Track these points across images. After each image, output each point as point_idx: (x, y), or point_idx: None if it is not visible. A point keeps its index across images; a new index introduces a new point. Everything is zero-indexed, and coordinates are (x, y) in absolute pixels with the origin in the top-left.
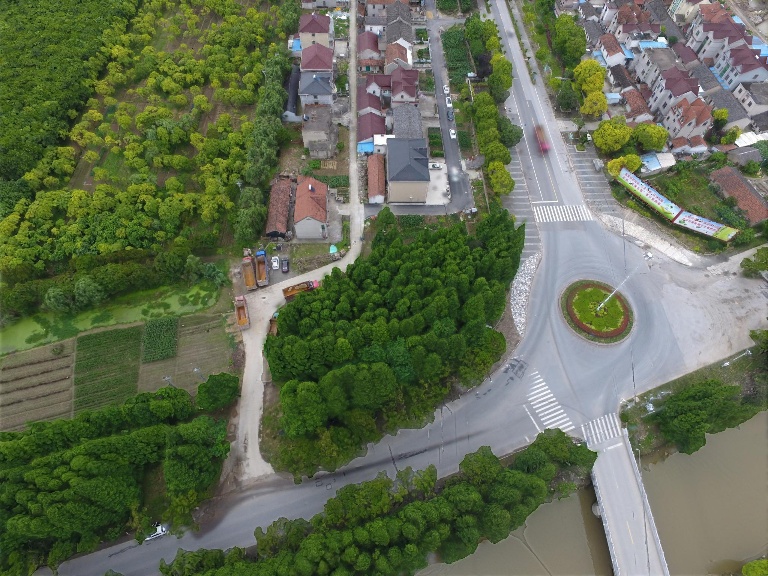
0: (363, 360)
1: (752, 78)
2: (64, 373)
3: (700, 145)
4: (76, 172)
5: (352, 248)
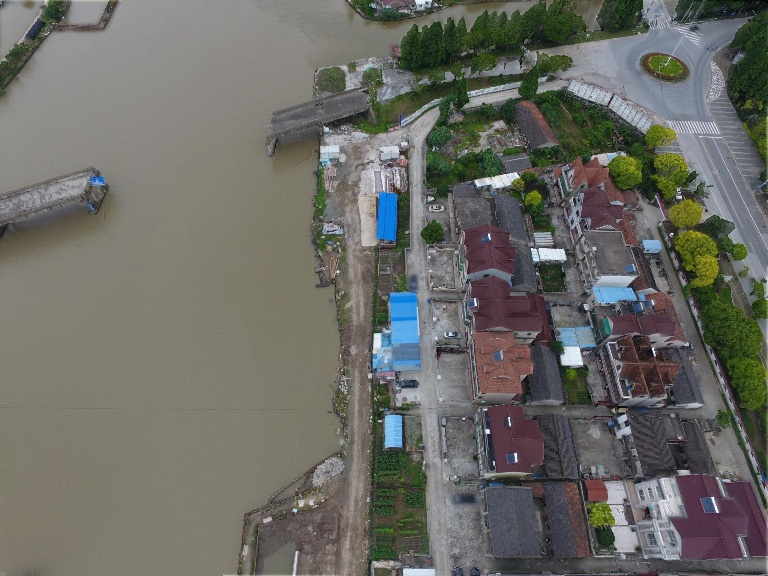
0: None
1: None
2: None
3: None
4: None
5: None
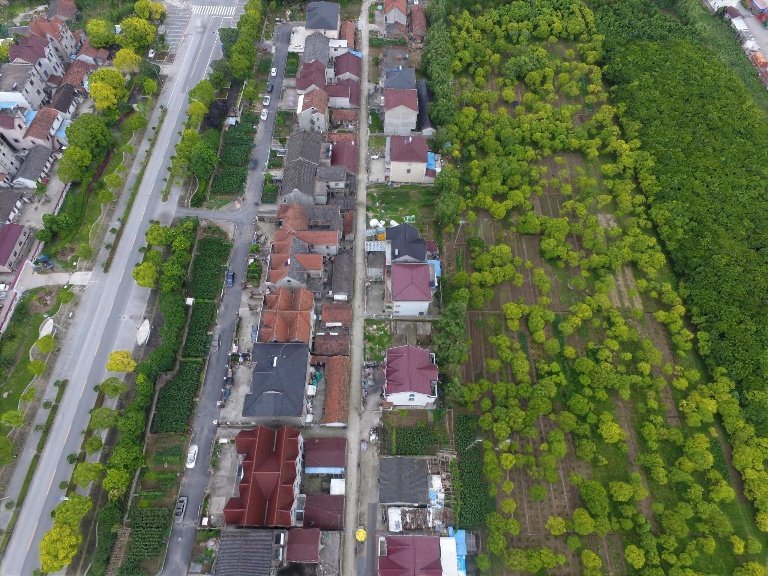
0: None
1: None
2: None
3: None
4: (579, 58)
5: (367, 8)
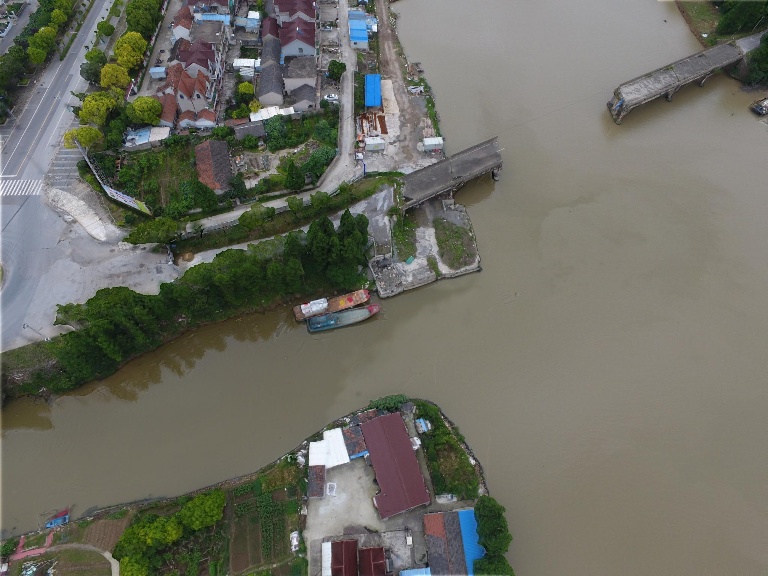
0: None
1: (299, 52)
2: None
3: (201, 119)
4: None
5: None
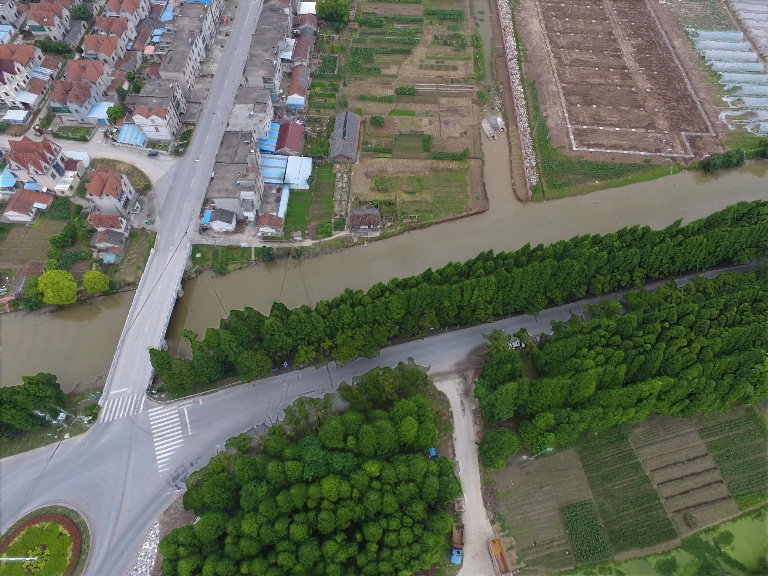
0: (352, 453)
1: None
2: (666, 491)
3: None
4: None
5: None
